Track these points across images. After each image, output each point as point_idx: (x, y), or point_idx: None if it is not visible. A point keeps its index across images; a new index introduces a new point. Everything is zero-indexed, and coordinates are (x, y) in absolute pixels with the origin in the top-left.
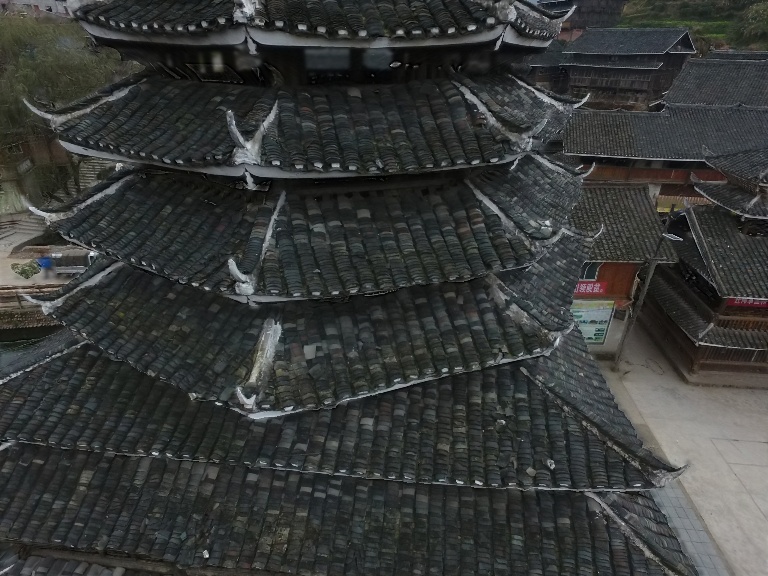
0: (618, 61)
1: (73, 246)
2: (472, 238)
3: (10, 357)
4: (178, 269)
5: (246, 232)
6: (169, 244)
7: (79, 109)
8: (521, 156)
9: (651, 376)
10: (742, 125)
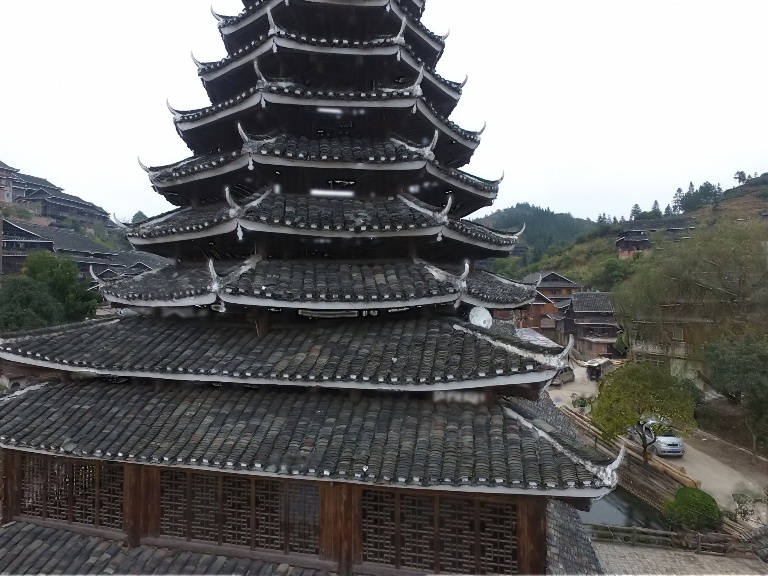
0: None
1: None
2: None
3: None
4: None
5: None
6: None
7: None
8: (163, 185)
9: None
10: None
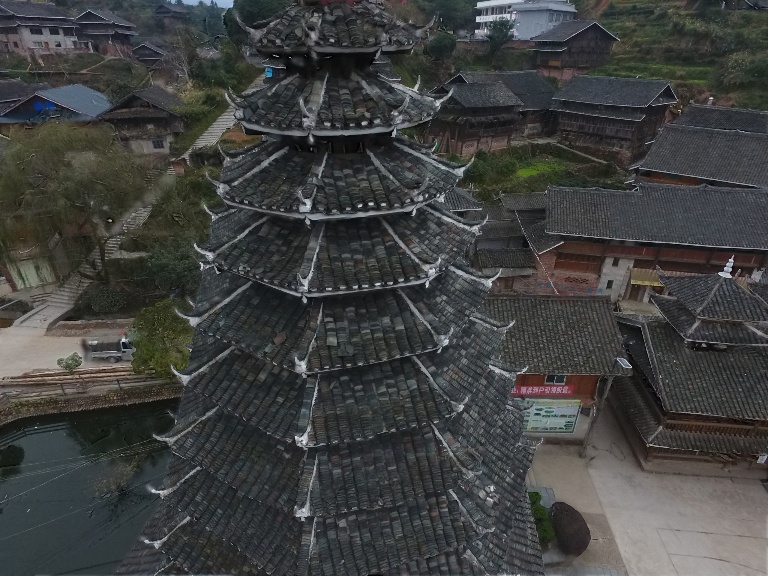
0: (604, 110)
1: (102, 321)
2: (439, 521)
3: (53, 435)
4: (255, 554)
5: (297, 529)
6: (246, 526)
7: (185, 430)
8: None
9: (613, 462)
10: (707, 207)
